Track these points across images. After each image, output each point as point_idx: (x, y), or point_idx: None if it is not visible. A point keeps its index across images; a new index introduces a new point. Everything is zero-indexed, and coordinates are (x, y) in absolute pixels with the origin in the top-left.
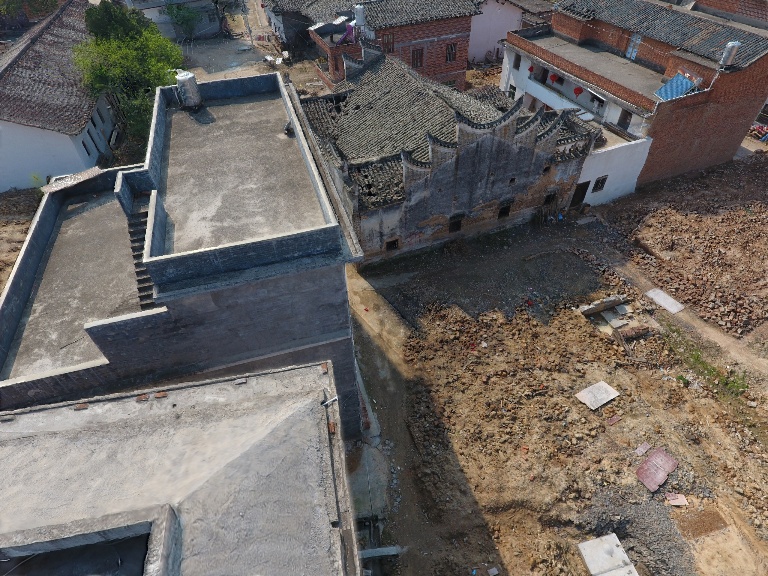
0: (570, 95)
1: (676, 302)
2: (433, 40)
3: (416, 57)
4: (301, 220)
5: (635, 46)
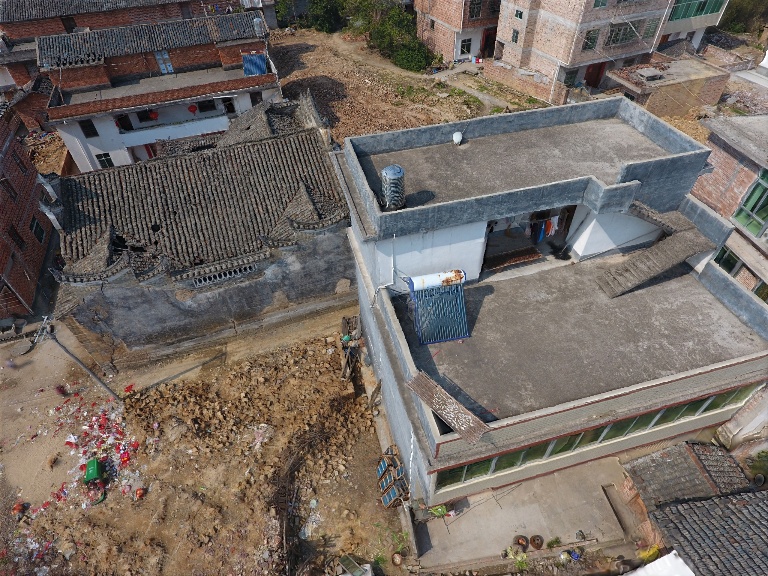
0: (174, 121)
1: None
2: (1, 158)
3: (5, 188)
4: (594, 128)
5: (166, 61)
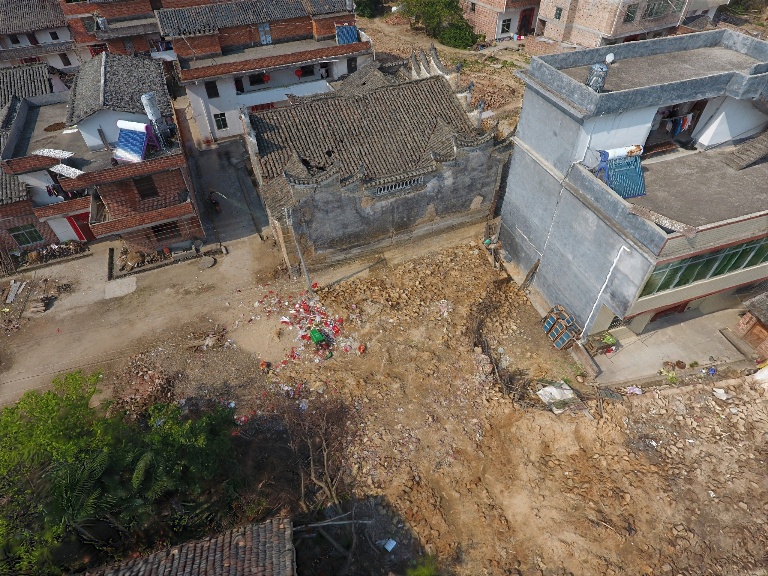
0: (278, 85)
1: (486, 112)
2: None
3: None
4: (707, 52)
5: (266, 33)
